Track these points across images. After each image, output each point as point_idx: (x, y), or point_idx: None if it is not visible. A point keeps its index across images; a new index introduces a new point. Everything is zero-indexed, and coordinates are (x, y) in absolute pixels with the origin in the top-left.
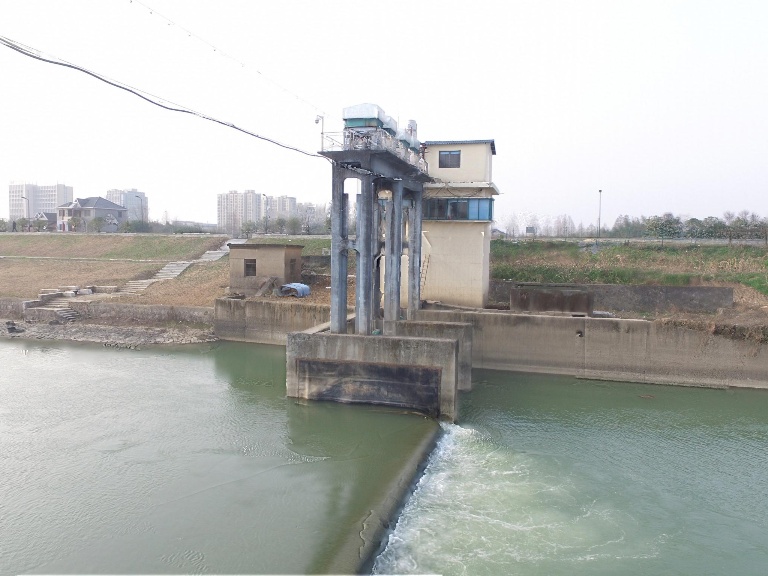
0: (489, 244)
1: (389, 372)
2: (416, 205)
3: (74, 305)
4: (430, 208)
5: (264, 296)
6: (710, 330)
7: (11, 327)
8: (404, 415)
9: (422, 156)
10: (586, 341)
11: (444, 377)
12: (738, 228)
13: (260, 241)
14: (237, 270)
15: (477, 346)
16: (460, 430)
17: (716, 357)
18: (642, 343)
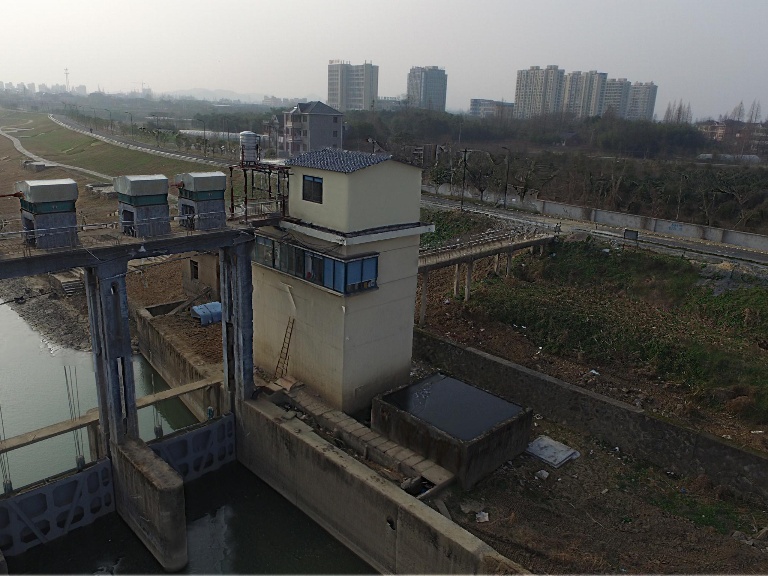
0: (409, 304)
1: None
2: (237, 262)
3: (82, 277)
4: (289, 257)
5: (179, 314)
6: None
7: (17, 297)
8: None
9: None
10: (398, 538)
11: None
12: None
13: None
14: (186, 270)
15: (291, 475)
16: None
17: None
18: None
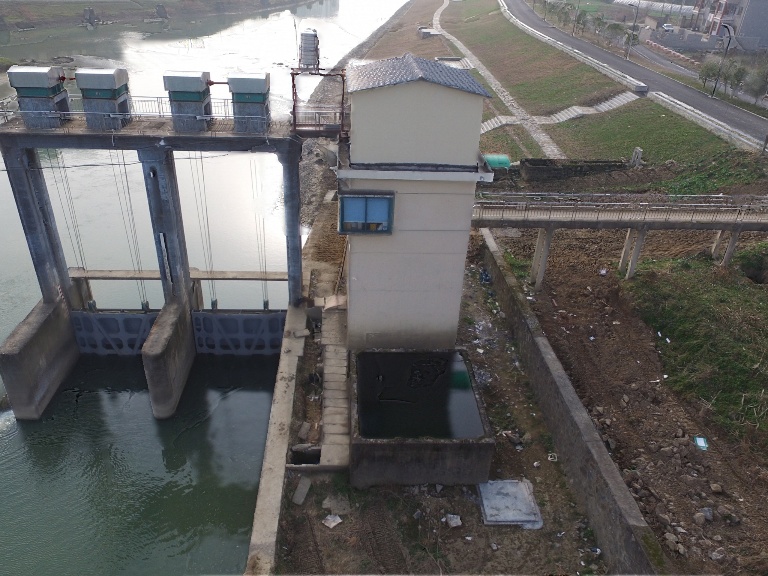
0: (455, 262)
1: None
2: None
3: None
4: None
5: None
6: None
7: None
8: None
9: None
10: None
11: None
12: None
13: (636, 106)
14: None
15: None
16: None
17: None
18: None
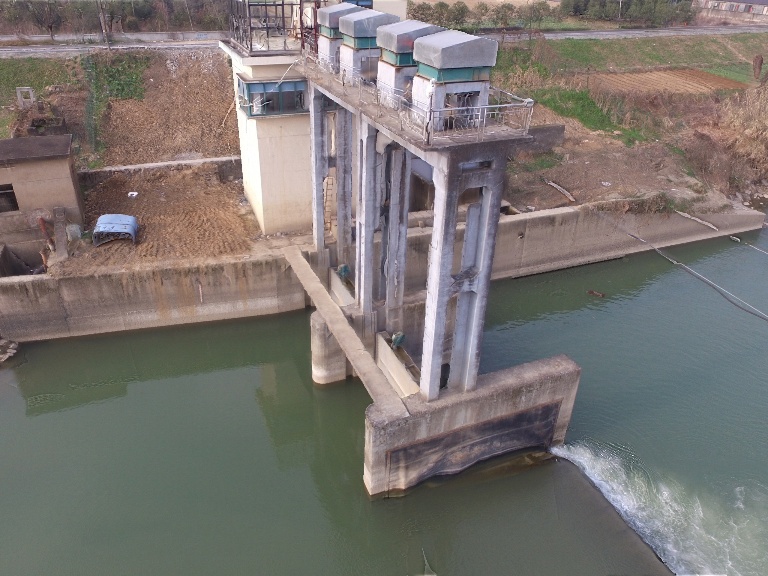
0: None
1: (505, 423)
2: None
3: None
4: None
5: (71, 254)
6: (625, 210)
7: None
8: (535, 467)
9: (316, 7)
10: (525, 241)
11: (563, 407)
12: (480, 14)
13: None
14: None
15: (420, 271)
16: (583, 455)
17: (622, 232)
18: (571, 232)
